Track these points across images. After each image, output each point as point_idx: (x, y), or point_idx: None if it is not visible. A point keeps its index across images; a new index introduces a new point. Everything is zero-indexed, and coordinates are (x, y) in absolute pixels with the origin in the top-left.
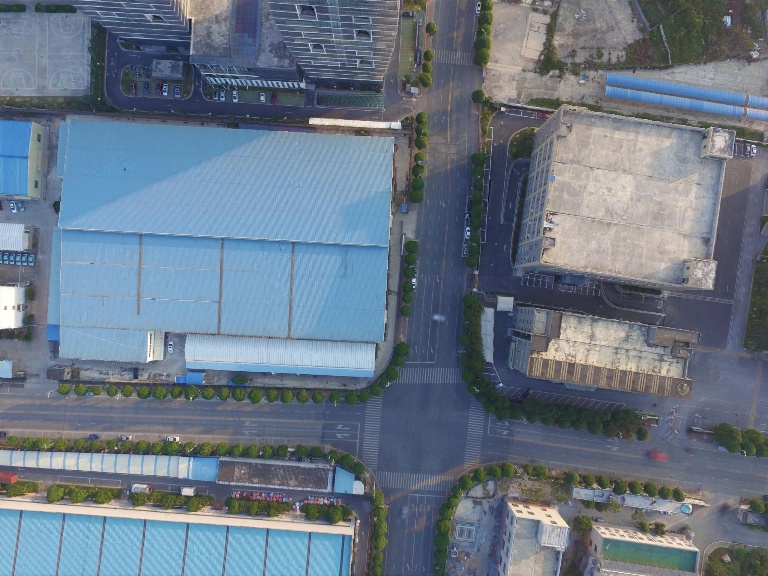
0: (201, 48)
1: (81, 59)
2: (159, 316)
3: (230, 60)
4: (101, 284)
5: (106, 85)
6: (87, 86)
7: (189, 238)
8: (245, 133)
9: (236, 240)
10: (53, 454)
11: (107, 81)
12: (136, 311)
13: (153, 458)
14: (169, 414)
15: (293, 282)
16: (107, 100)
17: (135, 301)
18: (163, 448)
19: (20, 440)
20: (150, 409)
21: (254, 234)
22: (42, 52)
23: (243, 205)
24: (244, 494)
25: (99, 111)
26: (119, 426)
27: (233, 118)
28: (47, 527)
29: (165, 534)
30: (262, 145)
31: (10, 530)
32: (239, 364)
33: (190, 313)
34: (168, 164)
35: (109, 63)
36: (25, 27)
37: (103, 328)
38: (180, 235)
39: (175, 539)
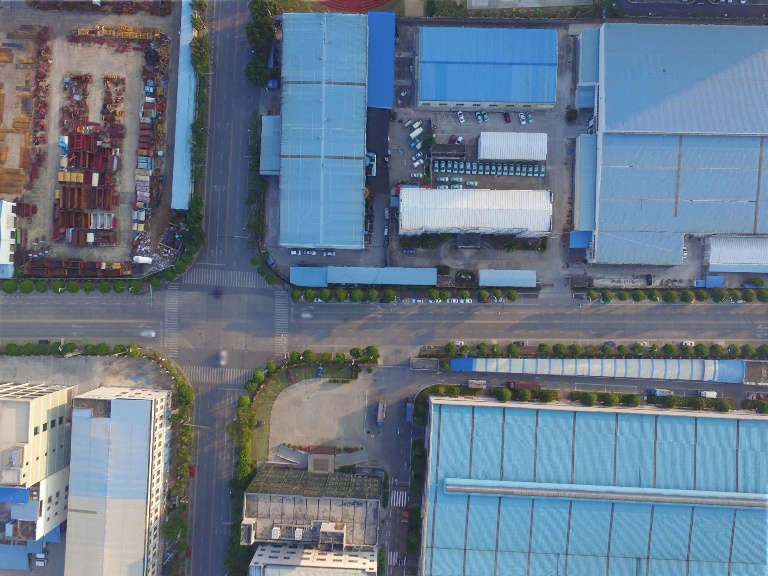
0: None
1: None
2: (696, 217)
3: None
4: (640, 187)
5: None
6: None
7: (729, 137)
8: None
9: None
10: (577, 361)
11: None
12: (673, 213)
13: (676, 362)
14: (682, 319)
15: None
16: (613, 7)
17: (673, 203)
18: (694, 350)
19: (537, 349)
20: (663, 315)
21: None
22: None
23: None
24: (762, 396)
25: (613, 17)
26: (633, 333)
27: (747, 19)
28: (601, 427)
29: (716, 431)
30: None
31: (565, 431)
32: (763, 265)
33: (727, 213)
34: (706, 64)
35: None
36: None
37: (640, 231)
38: (722, 134)
39: (727, 436)
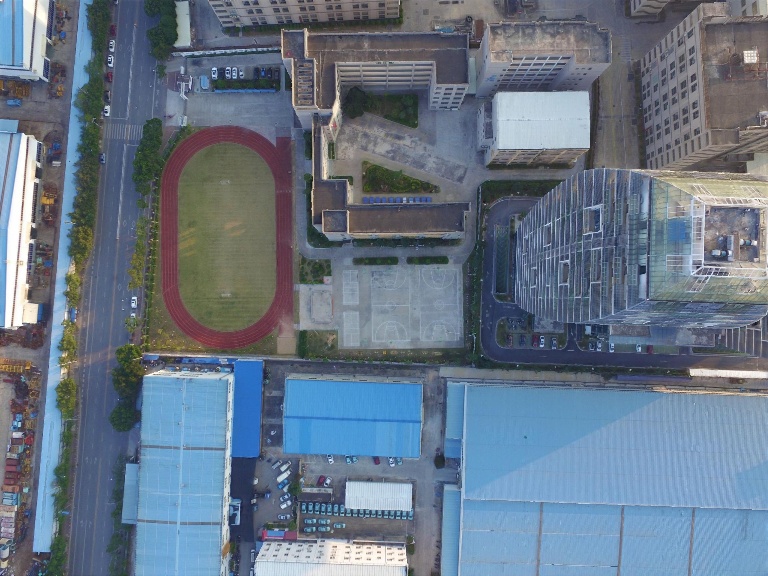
0: (619, 327)
1: (453, 310)
2: None
3: (650, 339)
4: (501, 551)
5: (481, 337)
6: (460, 337)
7: (590, 505)
8: (641, 396)
9: (637, 506)
10: None
11: (482, 333)
12: None
13: None
14: None
15: (693, 546)
16: (483, 352)
17: (534, 567)
18: None
19: None
20: None
21: (659, 502)
22: (415, 304)
23: (645, 472)
24: None
25: (481, 368)
26: None
27: None
28: None
29: None
30: (659, 408)
31: None
32: None
33: None
34: (567, 430)
35: (484, 315)
36: (397, 279)
37: None
38: (583, 503)
39: None
